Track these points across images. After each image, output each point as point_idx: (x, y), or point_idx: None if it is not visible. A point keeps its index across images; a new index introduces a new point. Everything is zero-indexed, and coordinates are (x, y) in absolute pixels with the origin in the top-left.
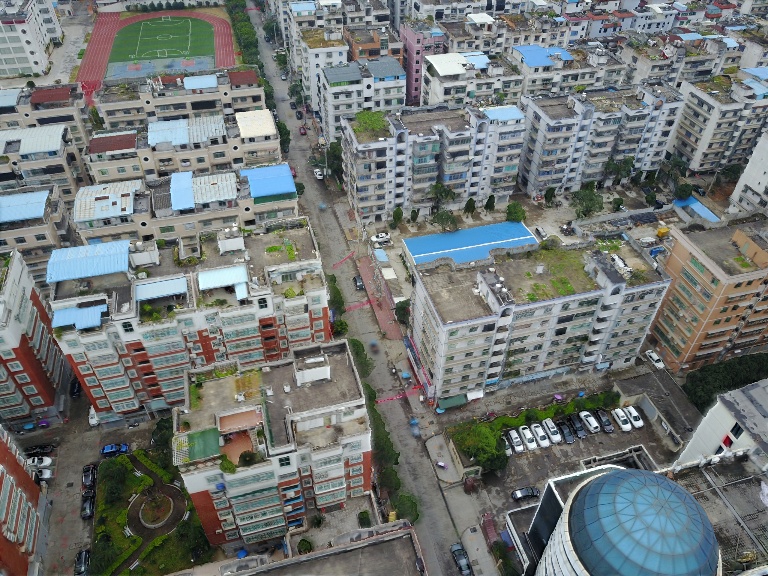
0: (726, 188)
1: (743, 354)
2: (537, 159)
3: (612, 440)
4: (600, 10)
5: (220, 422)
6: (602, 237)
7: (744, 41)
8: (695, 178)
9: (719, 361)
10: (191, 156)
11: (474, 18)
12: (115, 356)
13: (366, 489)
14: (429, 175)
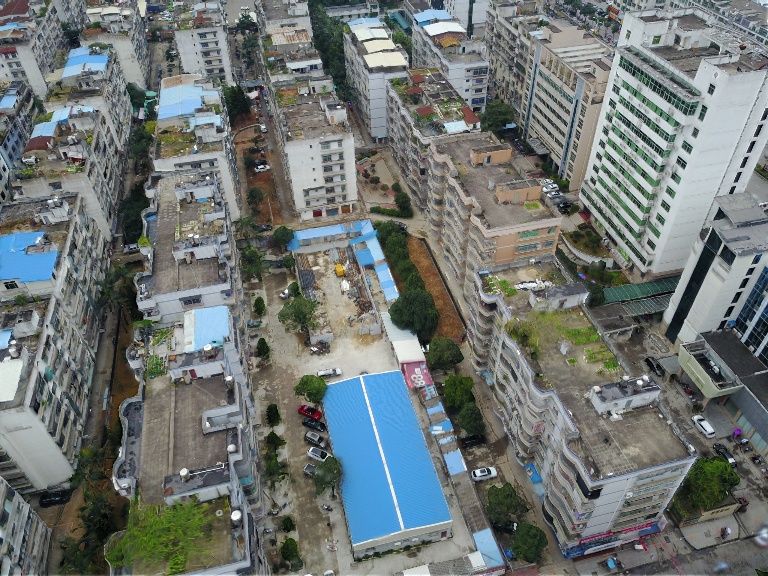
0: (262, 210)
1: None
2: None
3: None
4: None
5: None
6: (483, 290)
7: (76, 102)
8: (239, 225)
9: None
10: None
11: None
12: None
13: None
14: (255, 472)
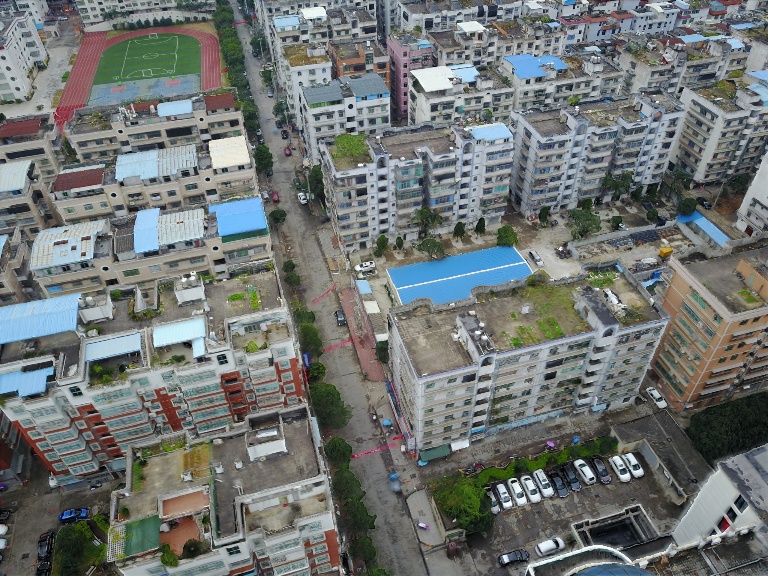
0: (734, 200)
1: (753, 389)
2: (529, 177)
3: (609, 492)
4: (598, 11)
5: (163, 506)
6: (594, 269)
7: (750, 41)
8: (700, 190)
9: (727, 398)
10: (161, 190)
11: (464, 27)
12: (66, 420)
13: (334, 565)
14: (414, 200)
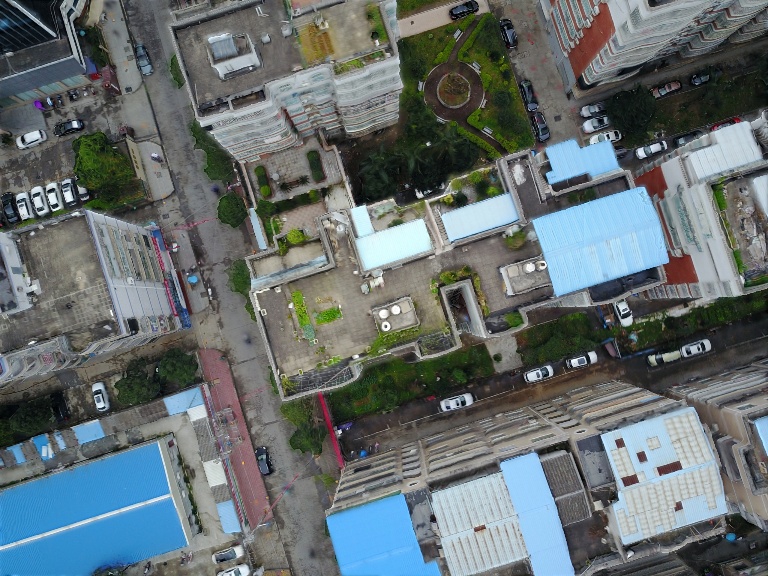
0: None
1: None
2: None
3: None
4: None
5: None
6: None
7: None
8: None
9: None
10: None
11: None
12: None
13: None
14: None
